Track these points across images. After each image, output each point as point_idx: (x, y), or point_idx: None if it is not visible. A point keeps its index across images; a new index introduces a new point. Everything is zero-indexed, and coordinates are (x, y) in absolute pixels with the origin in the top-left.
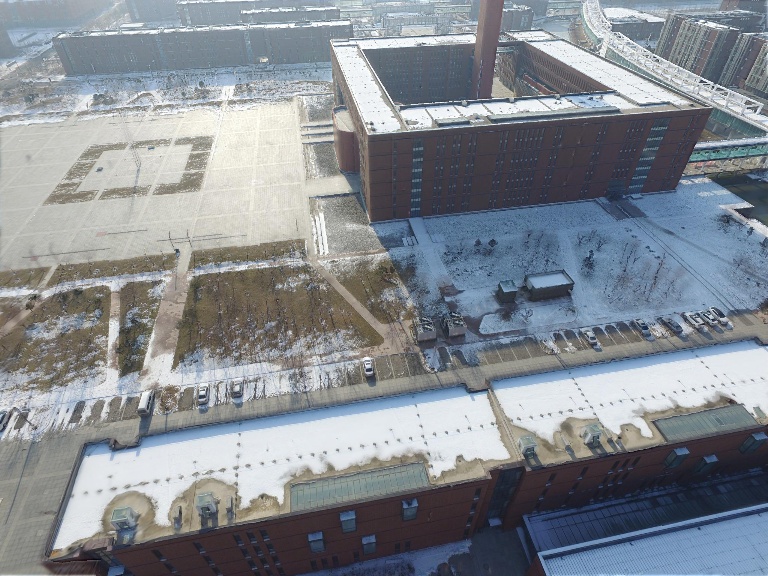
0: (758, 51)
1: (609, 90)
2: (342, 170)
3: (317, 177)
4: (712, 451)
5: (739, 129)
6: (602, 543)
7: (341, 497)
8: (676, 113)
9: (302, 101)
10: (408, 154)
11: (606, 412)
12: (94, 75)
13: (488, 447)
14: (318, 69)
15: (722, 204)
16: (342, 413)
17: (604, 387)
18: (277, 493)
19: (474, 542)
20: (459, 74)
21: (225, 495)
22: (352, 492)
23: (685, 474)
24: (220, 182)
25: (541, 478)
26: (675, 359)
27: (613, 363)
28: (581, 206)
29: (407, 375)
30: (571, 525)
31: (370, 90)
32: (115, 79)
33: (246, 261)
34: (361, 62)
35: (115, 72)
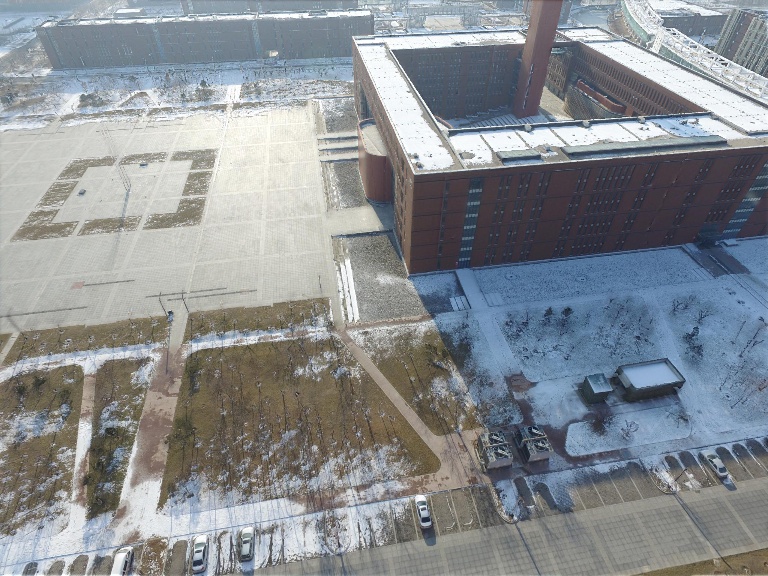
0: None
1: (704, 111)
2: (369, 199)
3: (340, 207)
4: None
5: None
6: None
7: None
8: None
9: (318, 106)
10: (462, 197)
11: None
12: (84, 69)
13: None
14: (334, 66)
15: None
16: None
17: None
18: None
19: None
20: (502, 79)
21: None
22: None
23: None
24: (224, 213)
25: None
26: None
27: None
28: (665, 255)
29: (477, 526)
30: None
31: (408, 106)
32: None
33: (256, 330)
34: (392, 66)
35: (107, 66)
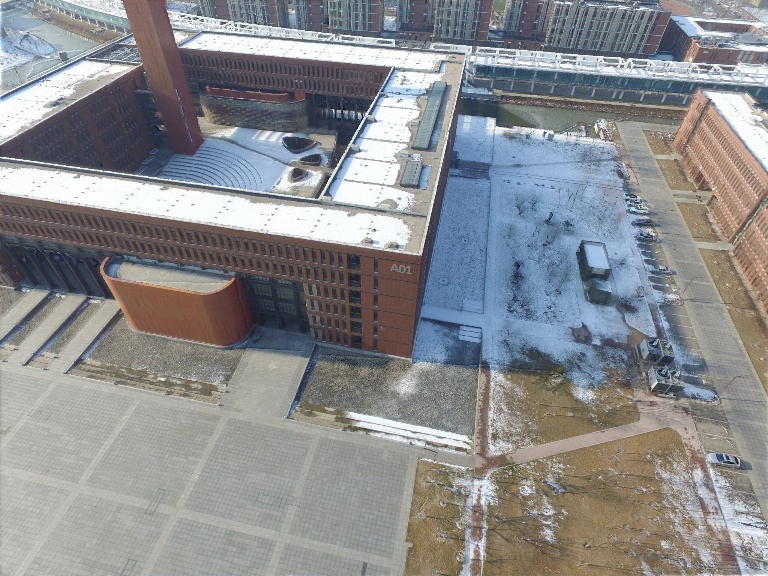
0: None
1: (391, 69)
2: (230, 345)
3: (221, 387)
4: None
5: None
6: None
7: None
8: None
9: None
10: None
11: None
12: None
13: None
14: None
15: (485, 127)
16: None
17: None
18: None
19: None
20: (133, 122)
21: None
22: None
23: None
24: None
25: None
26: None
27: None
28: (454, 186)
29: (728, 425)
30: None
31: (213, 203)
32: None
33: None
34: (51, 174)
35: None
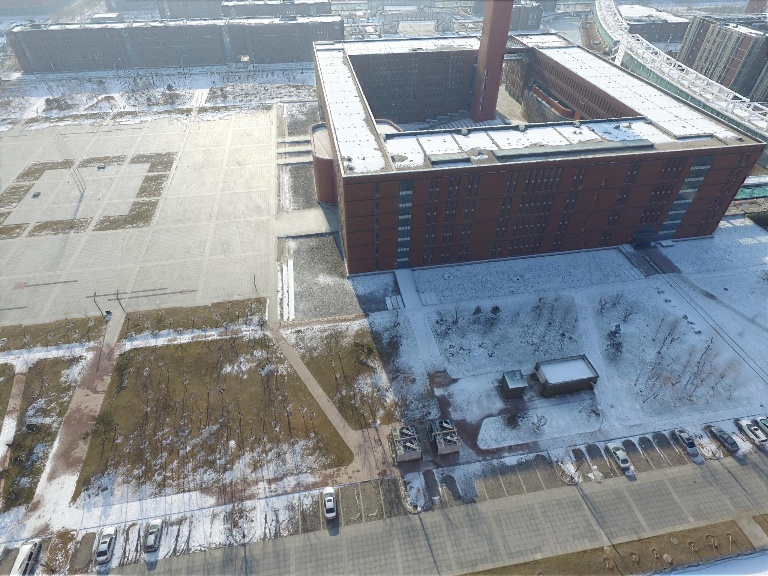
0: None
1: (638, 116)
2: (320, 201)
3: (290, 210)
4: None
5: None
6: None
7: None
8: (722, 150)
9: (282, 110)
10: (393, 198)
11: None
12: (54, 73)
13: None
14: (304, 70)
15: None
16: None
17: None
18: None
19: None
20: (460, 84)
21: None
22: None
23: None
24: (175, 215)
25: None
26: (764, 566)
27: None
28: (601, 255)
29: (381, 517)
30: None
31: (352, 110)
32: None
33: (191, 329)
34: (346, 71)
35: (78, 70)
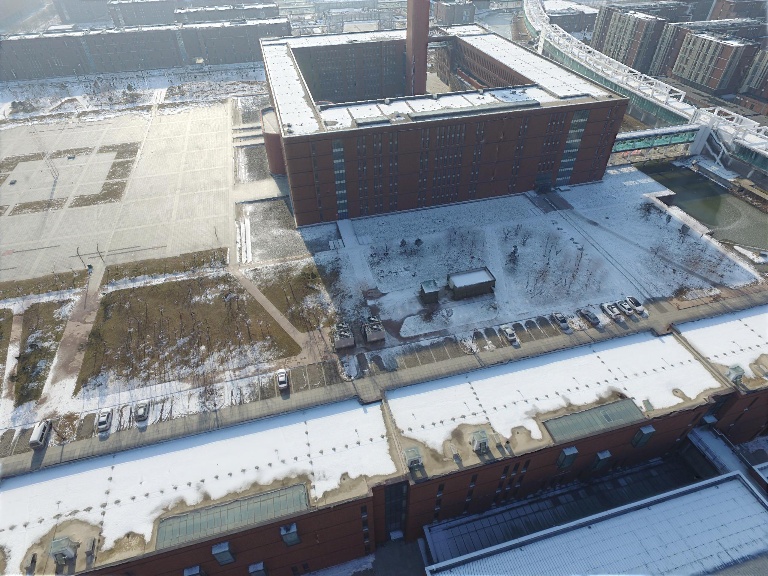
0: (683, 40)
1: (532, 83)
2: (272, 173)
3: (246, 181)
4: (604, 447)
5: (664, 118)
6: (499, 549)
7: (212, 529)
8: (594, 105)
9: (237, 102)
10: (328, 156)
11: (499, 416)
12: (16, 81)
13: (375, 462)
14: (256, 69)
15: (646, 192)
16: (226, 436)
17: (499, 389)
18: (145, 530)
19: (377, 557)
20: (394, 71)
21: (87, 537)
22: (225, 522)
23: (584, 471)
24: (143, 191)
25: (429, 490)
26: (572, 356)
27: (510, 364)
28: (510, 200)
29: (323, 385)
30: (471, 532)
31: (293, 90)
32: (37, 85)
33: (163, 274)
34: (288, 61)
35: (39, 77)
